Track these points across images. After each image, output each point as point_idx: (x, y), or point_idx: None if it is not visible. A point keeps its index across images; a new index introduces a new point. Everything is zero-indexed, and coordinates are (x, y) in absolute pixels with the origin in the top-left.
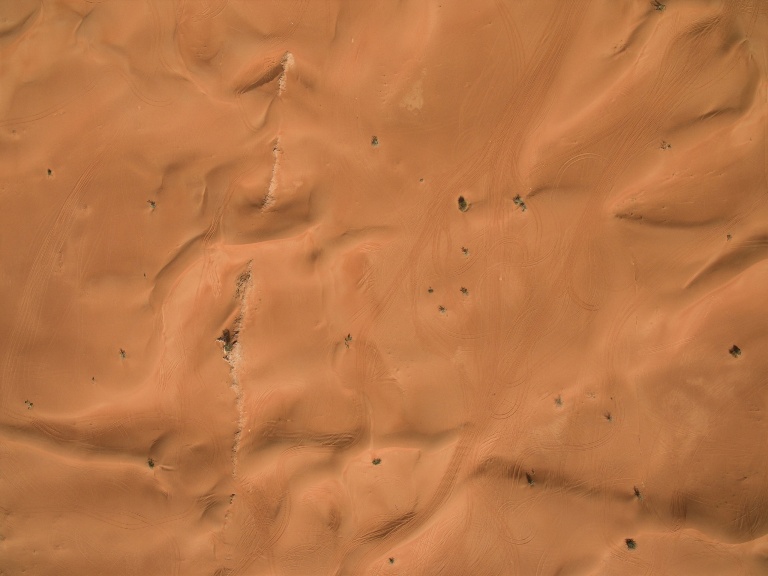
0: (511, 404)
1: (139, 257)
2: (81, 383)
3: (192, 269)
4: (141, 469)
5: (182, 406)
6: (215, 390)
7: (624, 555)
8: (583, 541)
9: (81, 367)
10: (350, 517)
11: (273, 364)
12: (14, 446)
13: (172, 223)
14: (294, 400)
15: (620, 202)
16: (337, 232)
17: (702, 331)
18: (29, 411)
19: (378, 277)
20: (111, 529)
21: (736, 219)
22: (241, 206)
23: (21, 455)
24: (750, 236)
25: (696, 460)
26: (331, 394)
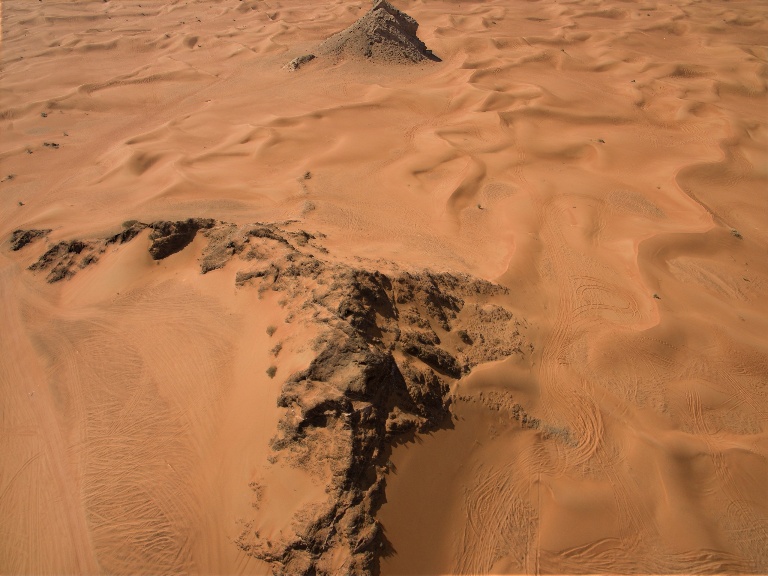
0: None
1: None
2: None
3: None
4: None
5: None
6: None
7: None
8: None
9: None
10: None
11: None
12: None
13: None
14: None
15: None
16: None
17: None
18: None
19: None
20: None
21: None
22: (257, 6)
23: None
24: None
25: None
26: None
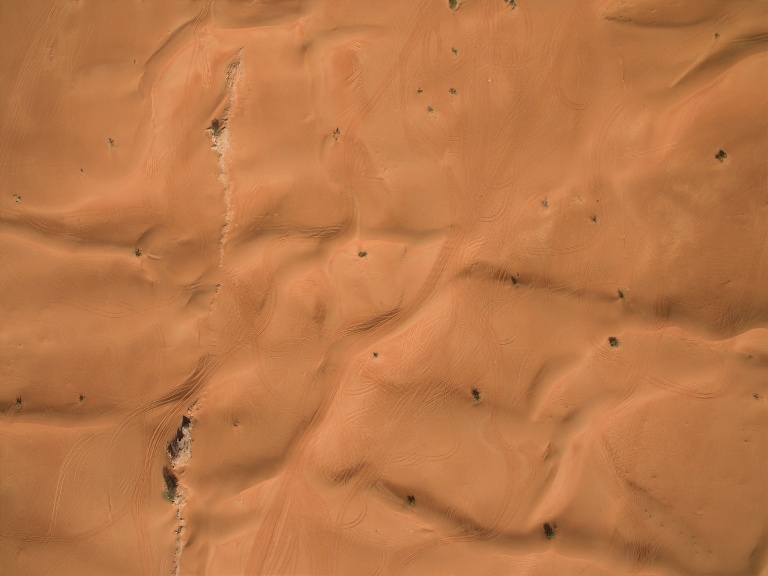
0: (498, 206)
1: (130, 45)
2: (69, 175)
3: (182, 54)
4: (128, 259)
5: (170, 201)
6: (203, 183)
7: (607, 354)
8: (566, 338)
9: (70, 159)
10: (335, 308)
11: (261, 156)
12: (1, 238)
13: (163, 9)
14: (282, 195)
15: (610, 5)
16: (328, 26)
17: (689, 136)
18: (17, 205)
19: (368, 77)
20: (97, 319)
21: (724, 18)
22: None
23: (8, 247)
24: (738, 35)
25: (681, 266)
26: (319, 188)
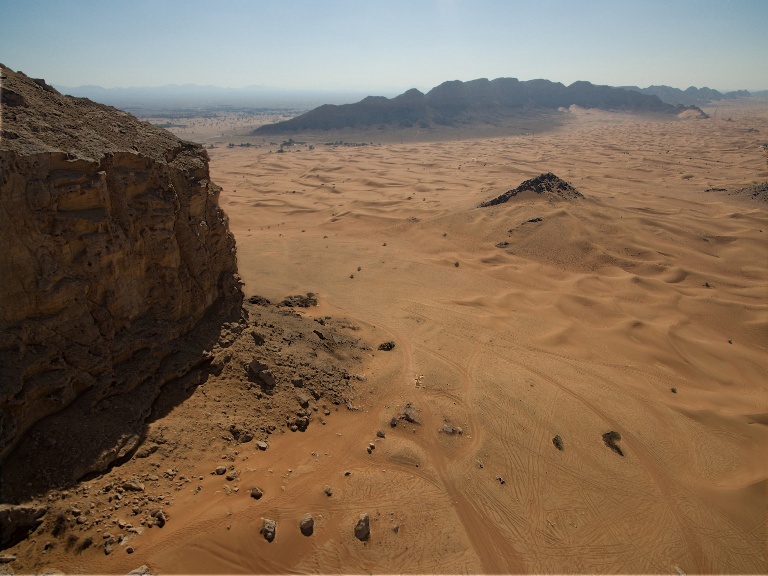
0: None
1: None
2: None
3: None
4: None
5: None
6: None
7: None
8: None
9: None
10: None
11: None
12: None
13: None
14: None
15: None
16: None
17: None
18: None
19: None
20: None
21: None
22: None
23: None
24: None
25: None
26: None
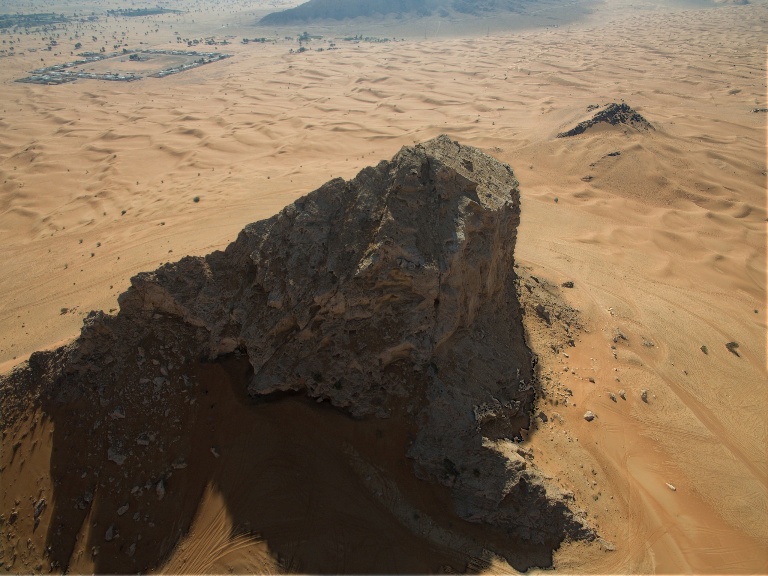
0: None
1: None
2: None
3: None
4: None
5: None
6: None
7: None
8: None
9: None
10: None
11: None
12: None
13: None
14: None
15: None
16: None
17: None
18: None
19: None
20: None
21: None
22: None
23: None
24: None
25: None
26: None
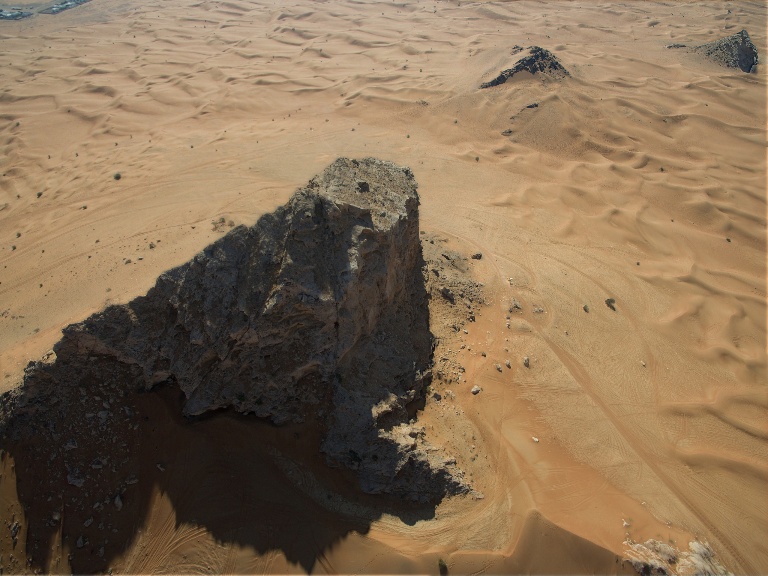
0: None
1: None
2: None
3: None
4: None
5: None
6: None
7: None
8: None
9: None
10: None
11: None
12: None
13: None
14: None
15: None
16: None
17: None
18: None
19: None
20: (748, 7)
21: None
22: None
23: None
24: None
25: (633, 2)
26: None
